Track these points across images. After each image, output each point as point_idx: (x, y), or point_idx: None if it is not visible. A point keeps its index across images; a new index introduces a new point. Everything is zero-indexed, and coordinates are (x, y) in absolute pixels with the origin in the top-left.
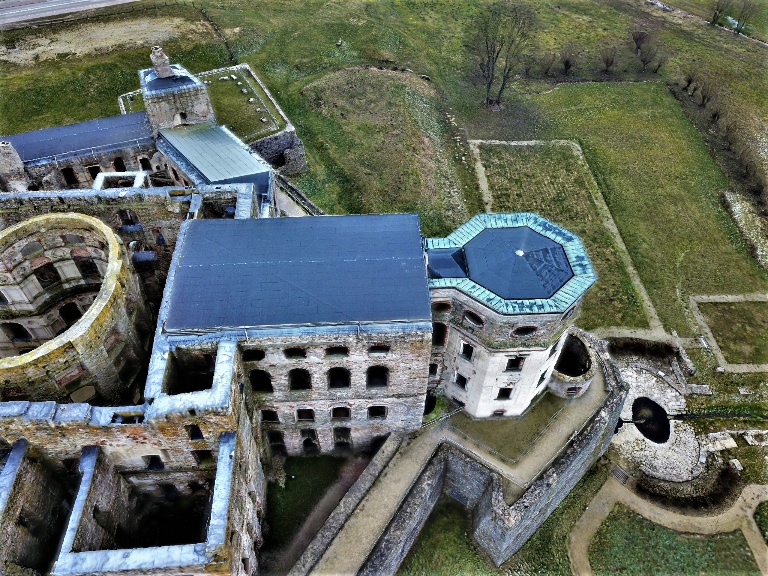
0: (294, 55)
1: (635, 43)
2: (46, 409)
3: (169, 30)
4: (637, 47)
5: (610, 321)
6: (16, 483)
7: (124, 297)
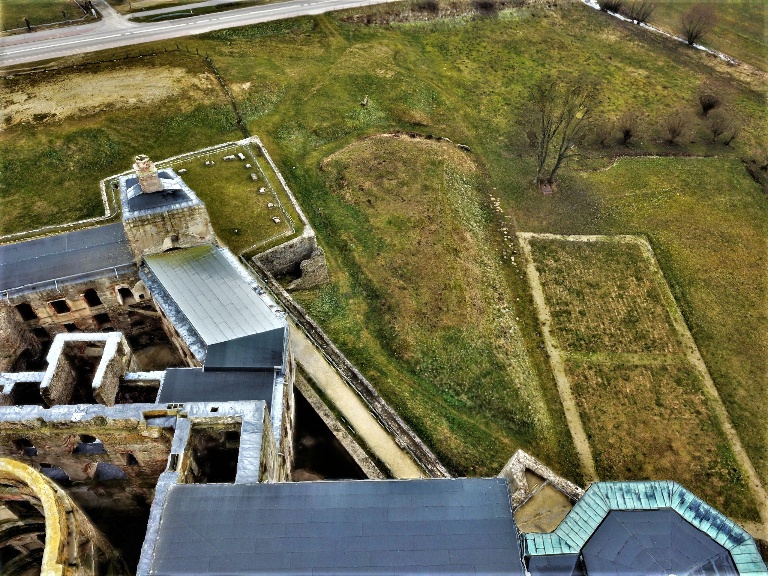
0: (312, 117)
1: (701, 107)
2: None
3: (168, 85)
4: (704, 112)
5: None
6: None
7: None
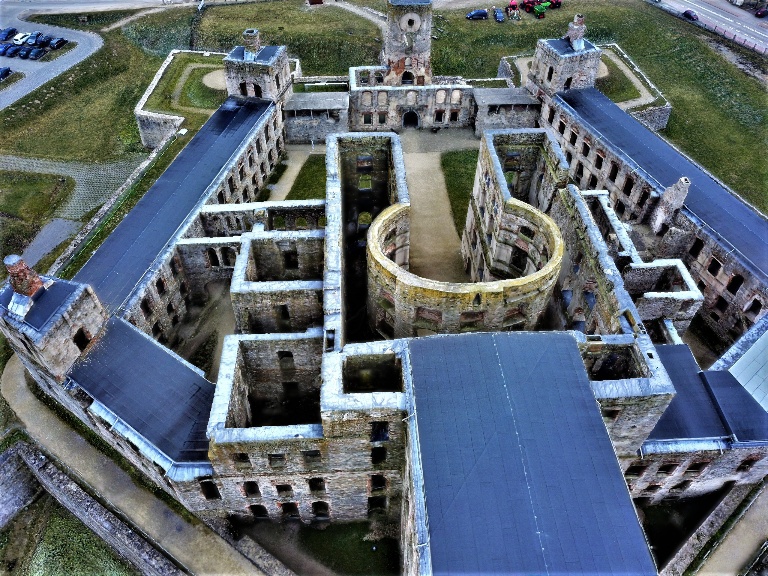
0: None
1: None
2: (333, 282)
3: None
4: None
5: None
6: (293, 291)
7: (468, 308)
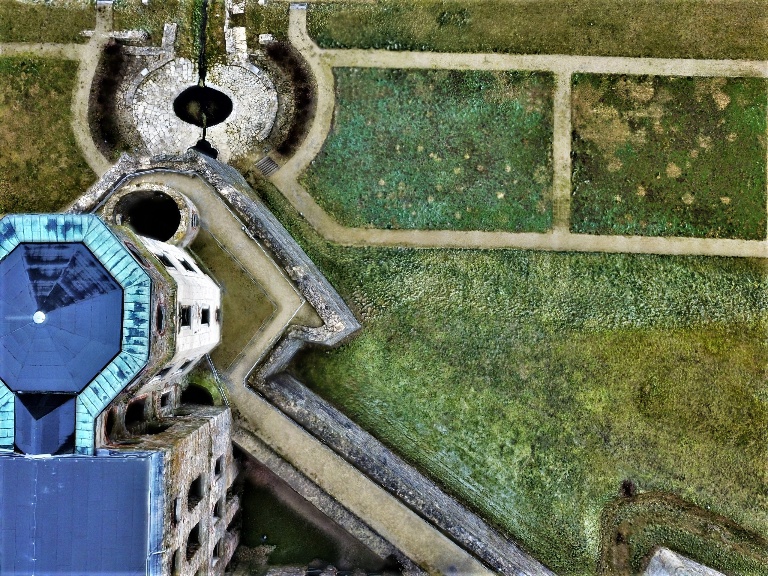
0: None
1: None
2: None
3: None
4: None
5: (62, 109)
6: None
7: None
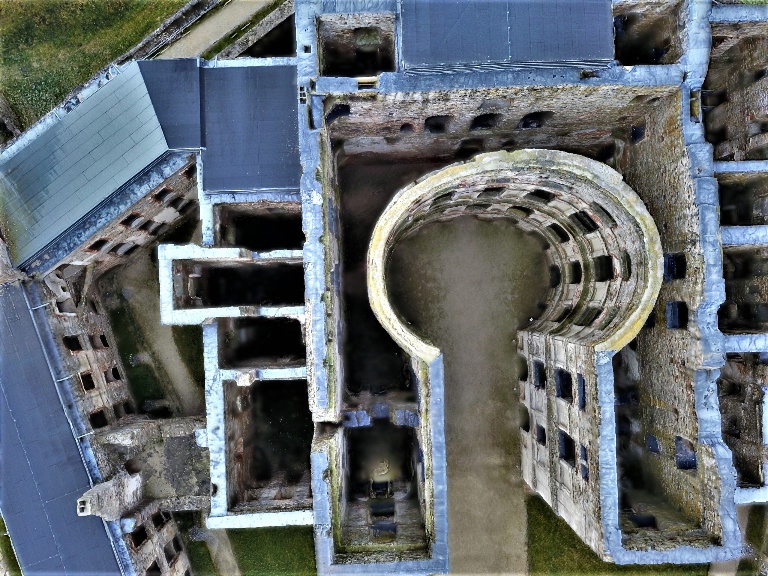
0: None
1: None
2: (706, 185)
3: None
4: None
5: None
6: None
7: None
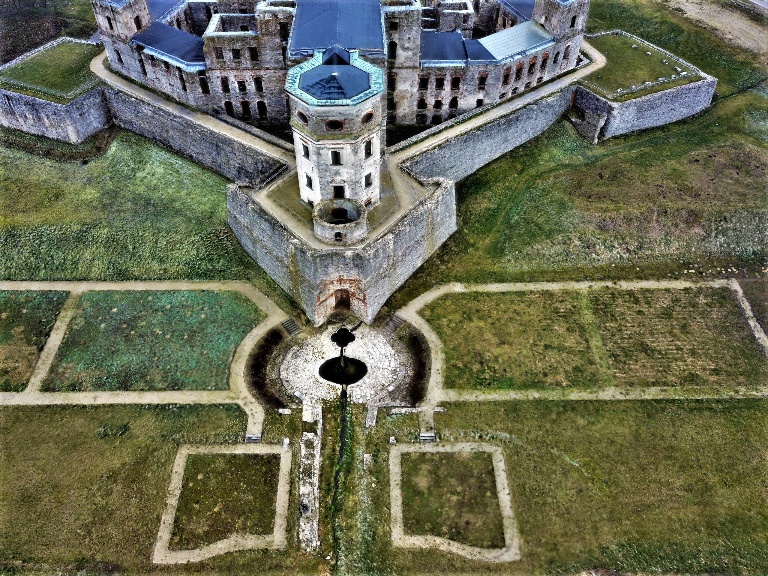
0: None
1: None
2: None
3: (765, 47)
4: None
5: (451, 354)
6: None
7: None
